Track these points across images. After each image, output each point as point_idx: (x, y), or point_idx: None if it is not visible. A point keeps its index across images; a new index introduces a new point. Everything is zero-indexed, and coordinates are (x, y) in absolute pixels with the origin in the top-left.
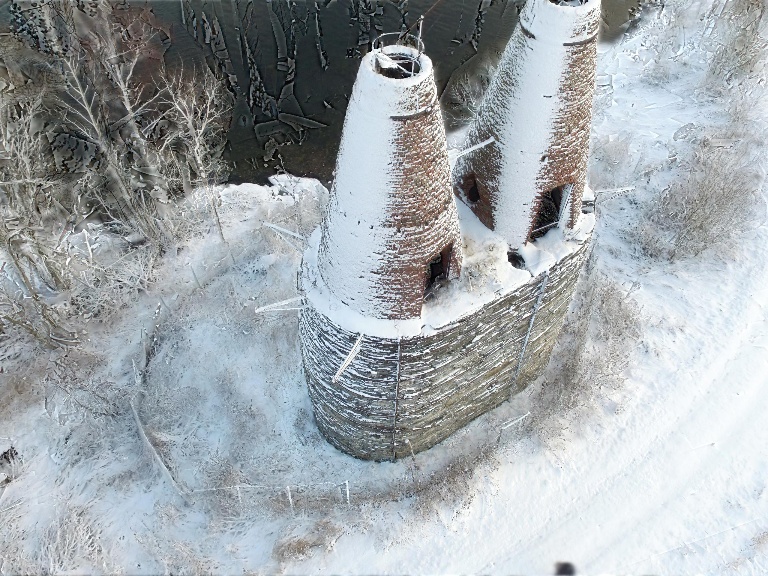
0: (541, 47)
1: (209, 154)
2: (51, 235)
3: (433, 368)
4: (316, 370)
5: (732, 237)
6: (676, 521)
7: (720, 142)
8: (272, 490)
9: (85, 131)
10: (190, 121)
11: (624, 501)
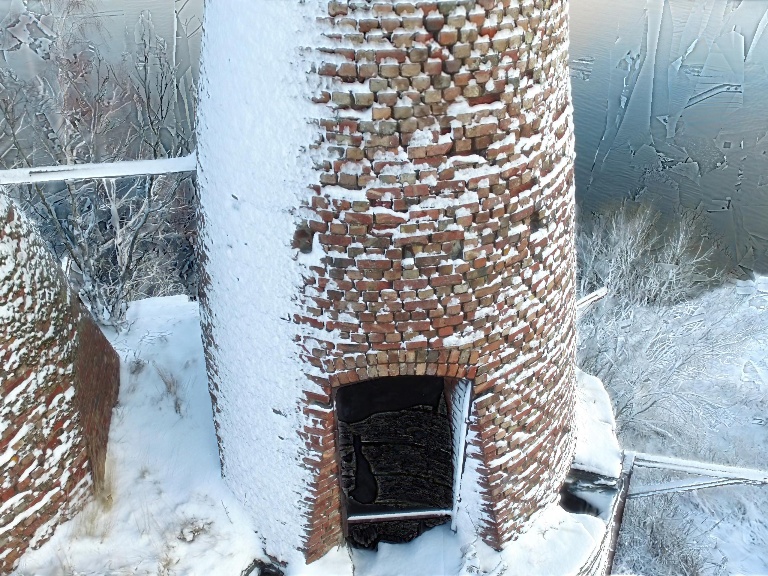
0: None
1: (186, 273)
2: None
3: None
4: None
5: None
6: None
7: None
8: None
9: None
10: (115, 205)
11: None
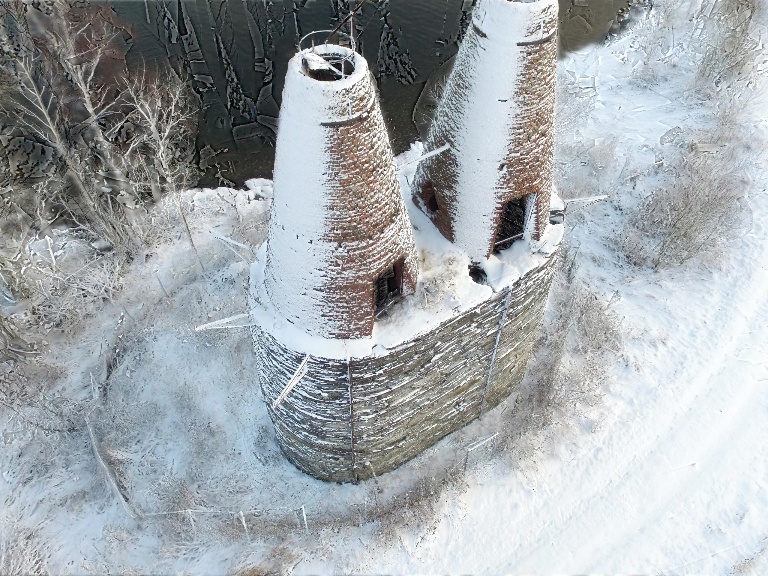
0: (493, 47)
1: (180, 158)
2: (11, 242)
3: (389, 389)
4: (269, 389)
5: (717, 246)
6: (653, 547)
7: (706, 147)
8: (228, 513)
9: (43, 134)
10: (153, 124)
11: (599, 526)
